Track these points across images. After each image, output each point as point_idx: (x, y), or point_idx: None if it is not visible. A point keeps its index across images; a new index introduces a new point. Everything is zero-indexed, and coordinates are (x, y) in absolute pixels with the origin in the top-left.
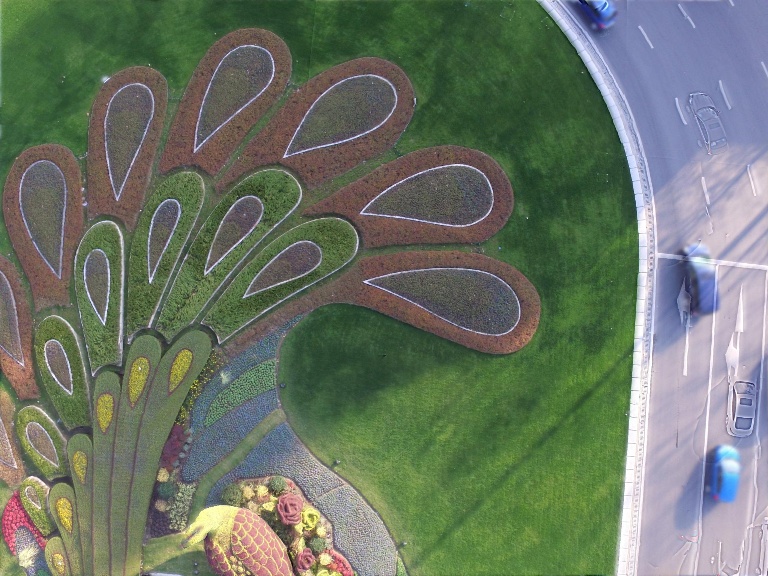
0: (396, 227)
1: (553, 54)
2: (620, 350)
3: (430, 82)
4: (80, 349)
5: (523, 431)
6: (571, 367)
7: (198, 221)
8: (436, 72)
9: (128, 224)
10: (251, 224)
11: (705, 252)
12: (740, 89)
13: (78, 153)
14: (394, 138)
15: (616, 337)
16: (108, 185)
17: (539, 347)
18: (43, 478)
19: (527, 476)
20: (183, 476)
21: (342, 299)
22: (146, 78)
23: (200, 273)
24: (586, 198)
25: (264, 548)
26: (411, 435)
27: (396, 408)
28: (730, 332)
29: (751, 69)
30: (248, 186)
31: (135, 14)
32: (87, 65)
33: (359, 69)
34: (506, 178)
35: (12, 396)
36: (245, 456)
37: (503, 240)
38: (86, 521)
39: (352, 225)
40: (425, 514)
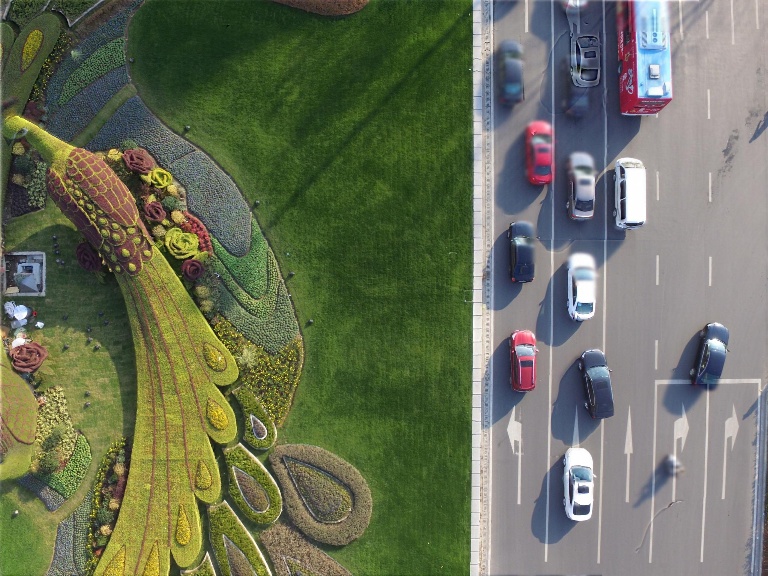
0: None
1: None
2: (459, 10)
3: None
4: None
5: (367, 88)
6: (411, 26)
7: None
8: None
9: None
10: None
11: None
12: None
13: None
14: None
15: None
16: None
17: (378, 9)
18: None
19: (374, 130)
20: None
21: None
22: None
23: None
24: None
25: (102, 178)
26: (258, 98)
27: (242, 74)
28: None
29: None
30: None
31: None
32: None
33: None
34: None
35: None
36: (99, 130)
37: None
38: None
39: None
40: (276, 173)
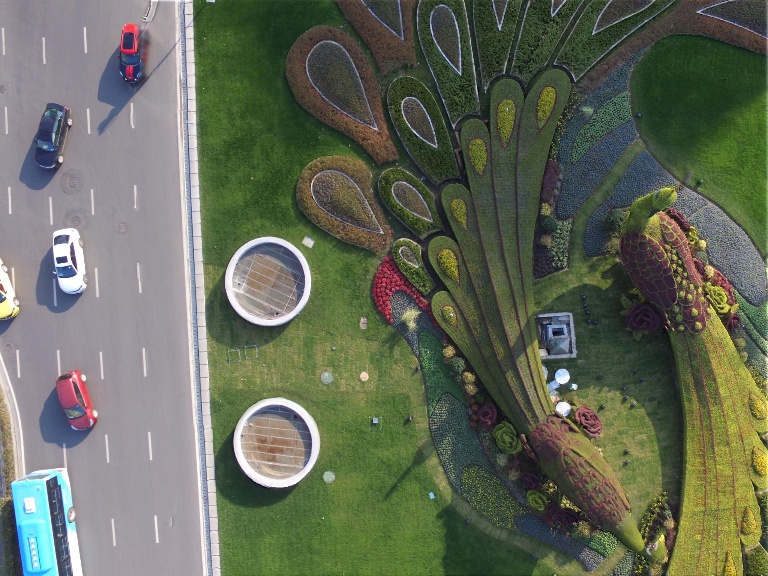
0: None
1: None
2: None
3: None
4: (437, 104)
5: None
6: None
7: None
8: None
9: None
10: None
11: None
12: None
13: None
14: None
15: None
16: None
17: None
18: (413, 239)
19: None
20: (559, 213)
21: (681, 29)
22: None
23: (548, 15)
24: None
25: None
26: (760, 150)
27: (743, 127)
28: None
29: None
30: None
31: None
32: None
33: None
34: None
35: (367, 163)
36: (614, 187)
37: None
38: (476, 265)
39: None
40: None
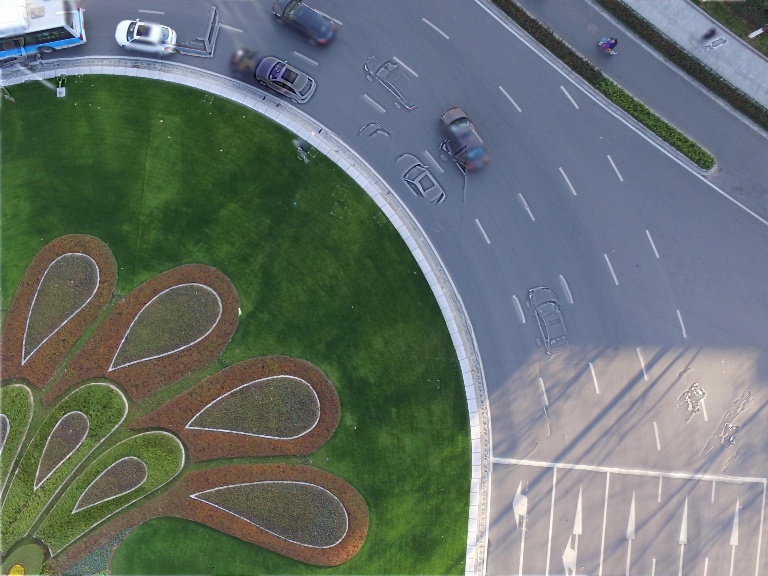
0: (221, 442)
1: (384, 254)
2: (452, 557)
3: (256, 288)
4: None
5: None
6: (401, 575)
7: (28, 434)
8: (262, 278)
9: None
10: (77, 440)
11: (542, 454)
12: (583, 282)
13: None
14: (219, 349)
15: (448, 544)
16: None
17: (368, 557)
18: None
19: None
20: None
21: (169, 514)
22: None
23: (29, 489)
24: (416, 406)
25: None
26: None
27: None
28: (567, 535)
29: (595, 261)
30: (73, 402)
31: None
32: None
33: (183, 278)
34: (333, 388)
35: None
36: None
37: (331, 451)
38: None
39: (178, 439)
40: None
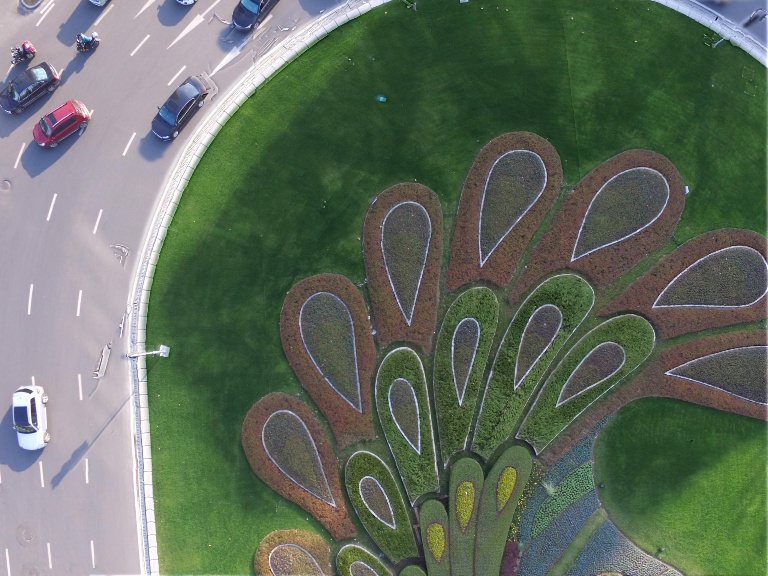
0: (689, 316)
1: None
2: None
3: (695, 167)
4: (395, 481)
5: None
6: None
7: (496, 336)
8: (699, 157)
9: (425, 348)
10: (552, 333)
11: None
12: None
13: (356, 280)
14: (672, 228)
15: None
16: (397, 311)
17: None
18: None
19: None
20: None
21: (648, 393)
22: (417, 195)
23: (510, 389)
24: None
25: None
26: (724, 512)
27: (708, 489)
28: None
29: None
30: (544, 295)
31: (389, 128)
32: (348, 187)
33: (630, 163)
34: None
35: (325, 538)
36: (574, 559)
37: None
38: None
39: (646, 319)
40: None
